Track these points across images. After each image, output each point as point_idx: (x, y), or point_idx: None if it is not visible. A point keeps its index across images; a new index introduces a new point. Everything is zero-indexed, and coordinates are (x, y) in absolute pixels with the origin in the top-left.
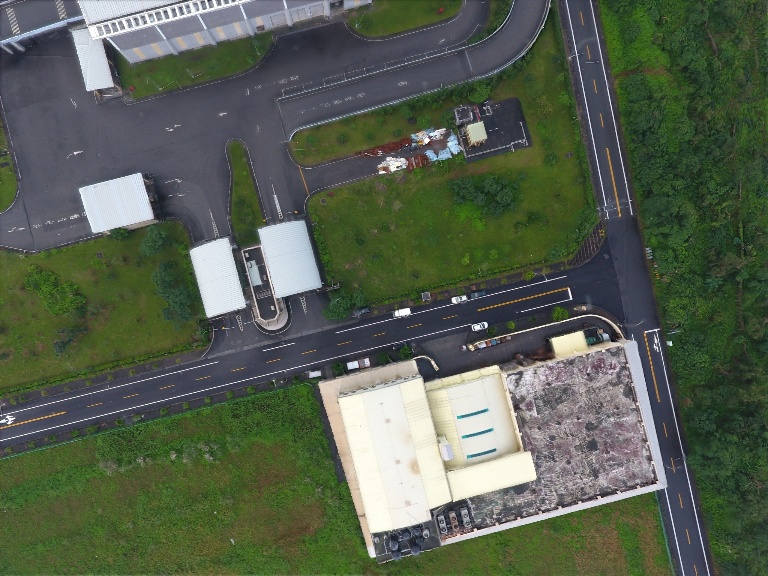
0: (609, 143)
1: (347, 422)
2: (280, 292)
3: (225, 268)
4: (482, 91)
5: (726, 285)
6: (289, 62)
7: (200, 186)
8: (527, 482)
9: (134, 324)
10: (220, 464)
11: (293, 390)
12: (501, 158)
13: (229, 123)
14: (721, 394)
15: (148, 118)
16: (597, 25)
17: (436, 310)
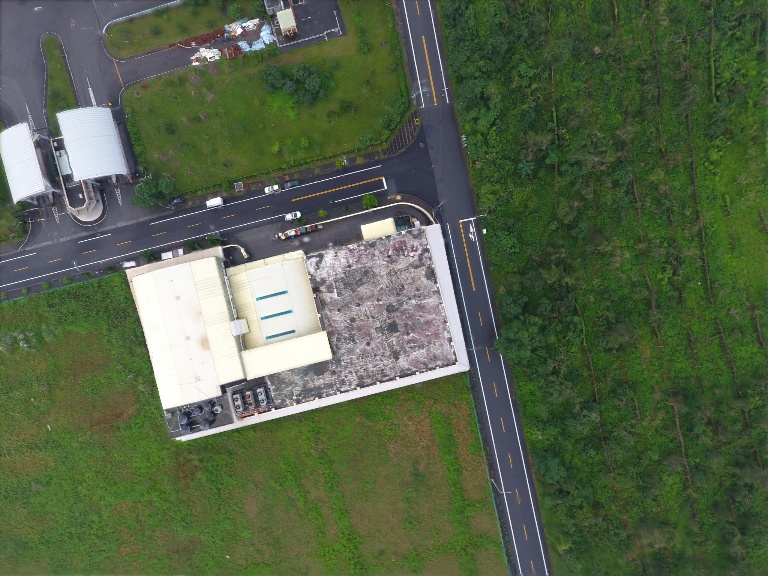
0: (425, 31)
1: (140, 300)
2: (78, 175)
3: (24, 152)
4: None
5: (541, 171)
6: None
7: (16, 80)
8: (327, 364)
9: None
10: (37, 353)
11: (107, 280)
12: (315, 47)
13: (44, 17)
14: (530, 279)
15: None
16: None
17: (250, 201)
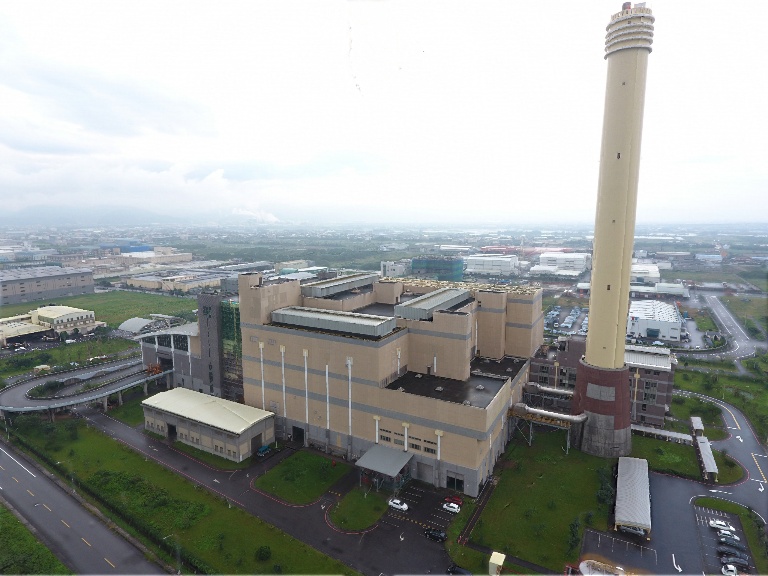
0: None
1: None
2: None
3: None
4: None
5: None
6: None
7: None
8: None
9: None
10: None
11: None
12: None
13: None
14: None
15: None
16: None
17: None
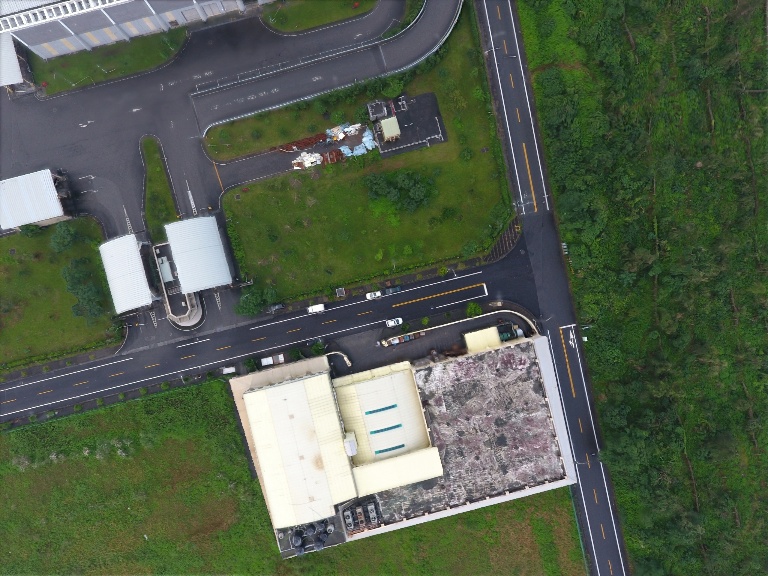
0: (525, 138)
1: (252, 418)
2: (187, 288)
3: (132, 264)
4: (394, 86)
5: (641, 280)
6: (203, 57)
7: (114, 182)
8: (436, 478)
9: (48, 320)
10: (134, 460)
11: (207, 386)
12: (416, 153)
13: (143, 119)
14: (634, 389)
15: (61, 114)
16: (514, 19)
17: (351, 306)
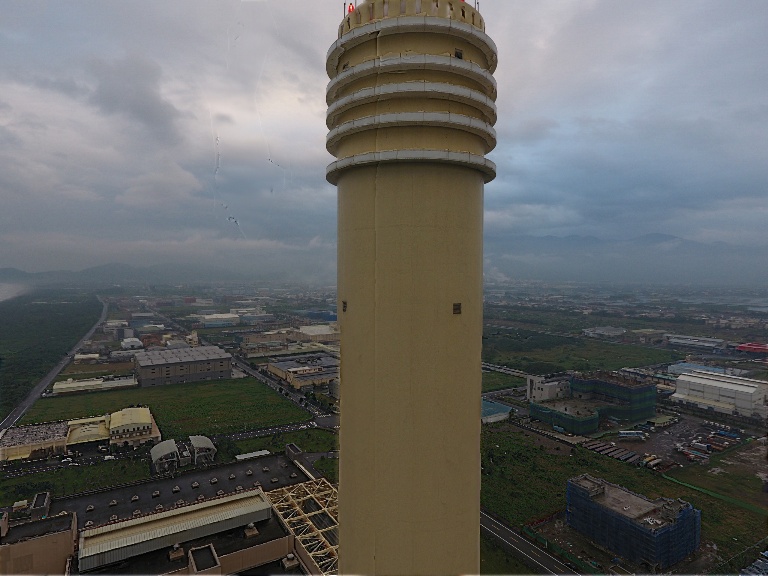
0: None
1: None
2: None
3: None
4: None
5: None
6: None
7: None
8: None
9: None
10: None
11: None
12: None
13: None
14: None
15: None
16: None
17: None
